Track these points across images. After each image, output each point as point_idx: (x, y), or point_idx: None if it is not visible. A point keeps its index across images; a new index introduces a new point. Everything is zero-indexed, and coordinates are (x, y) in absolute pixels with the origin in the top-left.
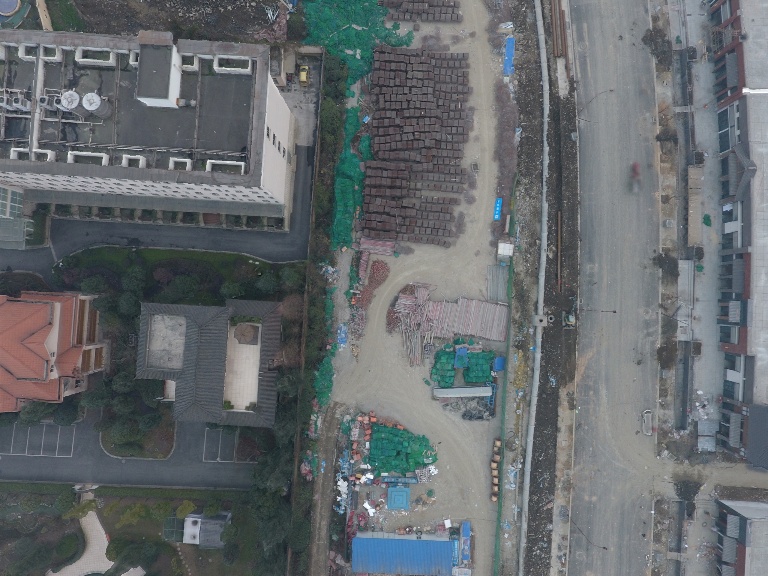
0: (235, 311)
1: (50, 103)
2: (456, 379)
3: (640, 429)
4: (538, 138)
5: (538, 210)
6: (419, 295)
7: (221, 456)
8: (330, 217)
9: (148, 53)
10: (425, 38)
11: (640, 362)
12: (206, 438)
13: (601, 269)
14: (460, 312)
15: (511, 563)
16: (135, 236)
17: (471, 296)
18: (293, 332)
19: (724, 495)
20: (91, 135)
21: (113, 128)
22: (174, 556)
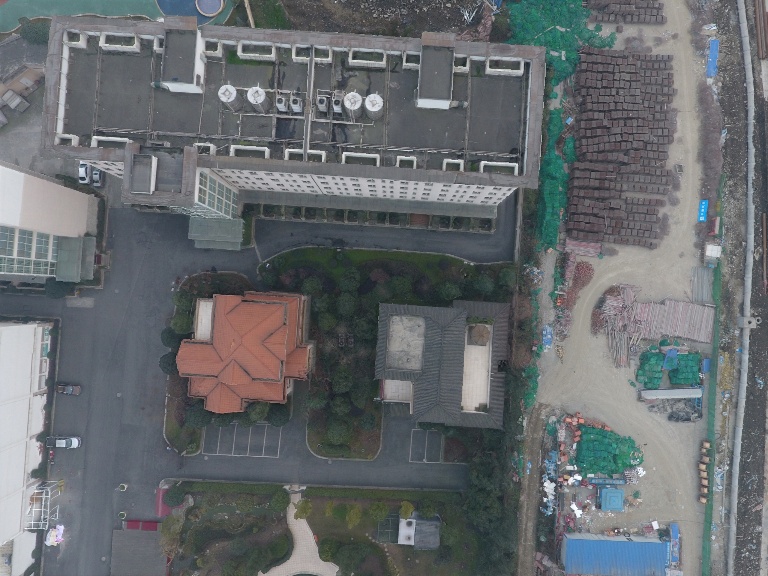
0: None
1: (326, 104)
2: (662, 381)
3: None
4: (742, 140)
5: (742, 212)
6: (626, 296)
7: (427, 457)
8: (535, 218)
9: (429, 54)
10: (628, 40)
11: None
12: (412, 439)
13: None
14: (668, 314)
15: (719, 565)
16: (339, 237)
17: (676, 298)
18: None
19: None
20: (362, 136)
21: (384, 129)
22: (383, 557)
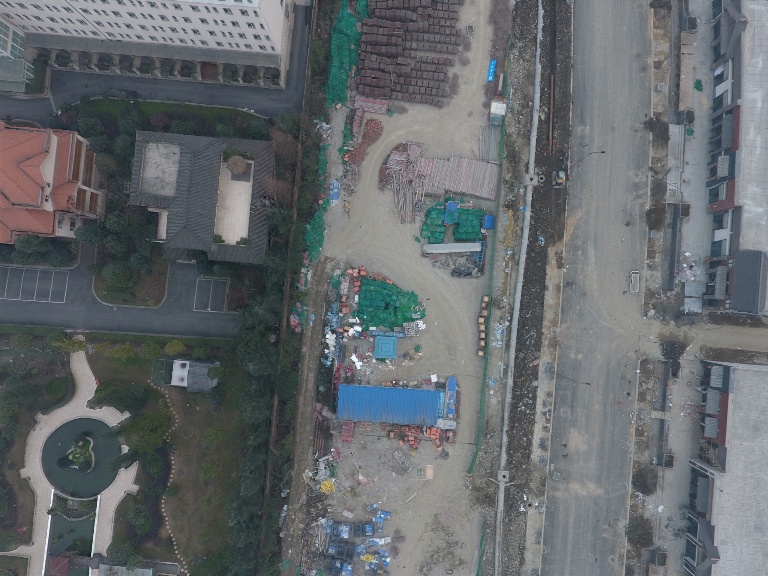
0: (229, 147)
1: None
2: (446, 237)
3: (627, 289)
4: (533, 2)
5: (531, 73)
6: (411, 152)
7: (212, 306)
8: (326, 75)
9: None
10: None
11: (629, 223)
12: (197, 288)
13: (592, 131)
14: (452, 169)
15: (496, 419)
16: (133, 89)
17: (463, 156)
18: (286, 184)
19: (709, 356)
20: None
21: None
22: None
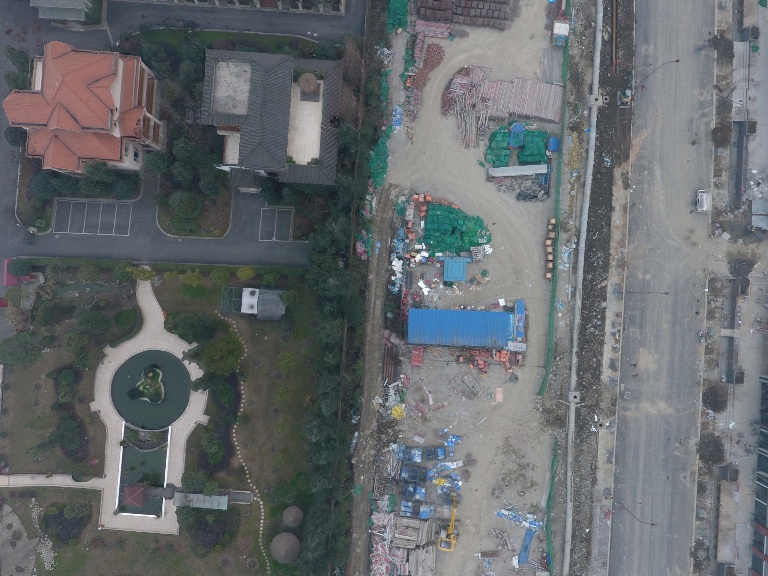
0: (297, 67)
1: None
2: (510, 161)
3: (694, 208)
4: None
5: None
6: (474, 75)
7: (277, 235)
8: None
9: None
10: None
11: (695, 142)
12: (262, 218)
13: (656, 51)
14: (515, 91)
15: (565, 342)
16: (191, 18)
17: (526, 79)
18: (349, 111)
19: None
20: None
21: None
22: None
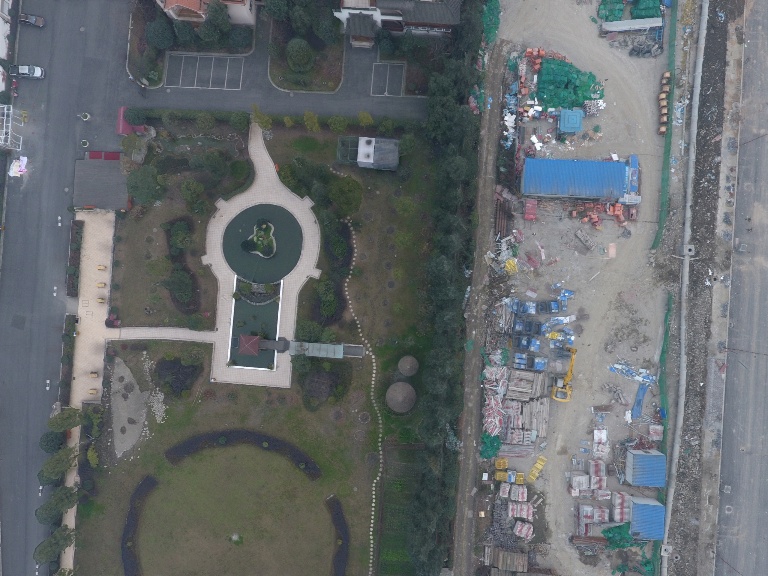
0: None
1: None
2: (623, 17)
3: None
4: None
5: None
6: None
7: (389, 90)
8: None
9: None
10: None
11: None
12: (374, 72)
13: None
14: None
15: (678, 197)
16: None
17: None
18: None
19: None
20: None
21: None
22: None
